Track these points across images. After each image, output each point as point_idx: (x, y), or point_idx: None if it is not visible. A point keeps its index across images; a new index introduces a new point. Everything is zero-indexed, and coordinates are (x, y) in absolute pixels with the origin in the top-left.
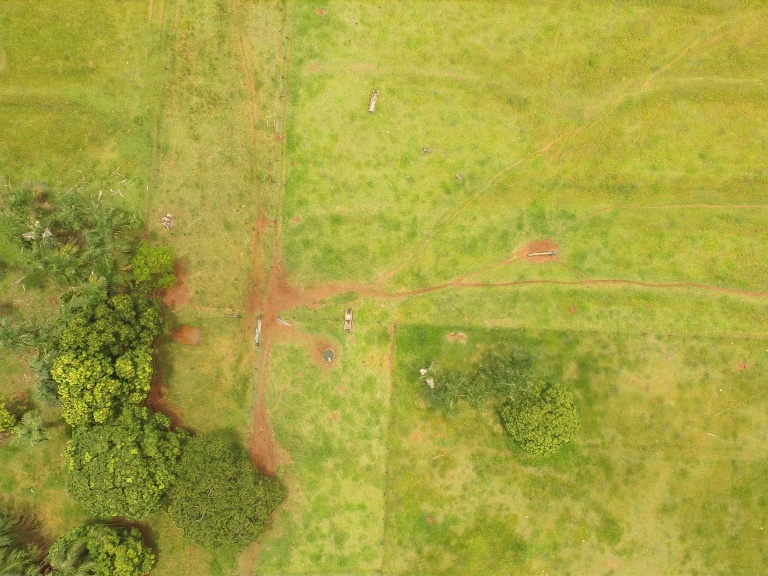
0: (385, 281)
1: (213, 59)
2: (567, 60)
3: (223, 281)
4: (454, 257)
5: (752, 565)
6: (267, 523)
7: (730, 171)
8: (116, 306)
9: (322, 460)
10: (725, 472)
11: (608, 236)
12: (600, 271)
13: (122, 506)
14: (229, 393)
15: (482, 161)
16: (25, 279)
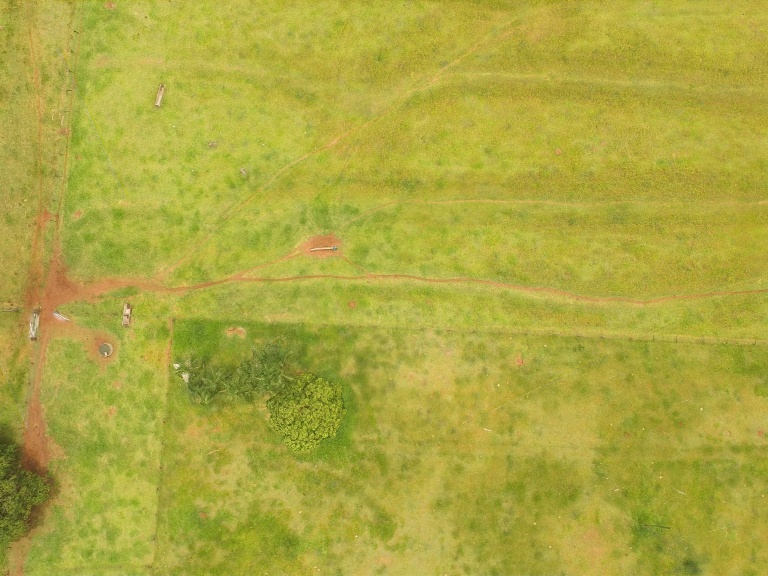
0: (166, 276)
1: (1, 52)
2: (356, 55)
3: (2, 275)
4: (236, 252)
5: (524, 560)
6: (39, 519)
7: (515, 166)
8: None
9: (96, 455)
10: (500, 467)
11: (391, 231)
12: (382, 266)
13: None
14: (4, 388)
15: (268, 156)
16: None
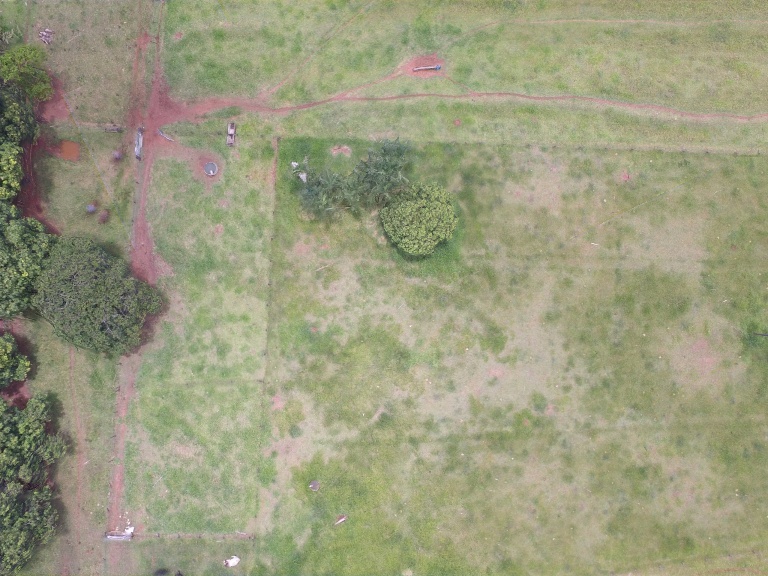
0: (269, 96)
1: None
2: None
3: (104, 96)
4: (339, 72)
5: (634, 371)
6: (148, 335)
7: None
8: None
9: (204, 273)
10: (609, 280)
11: (494, 51)
12: (485, 85)
13: None
14: (110, 207)
15: None
16: None
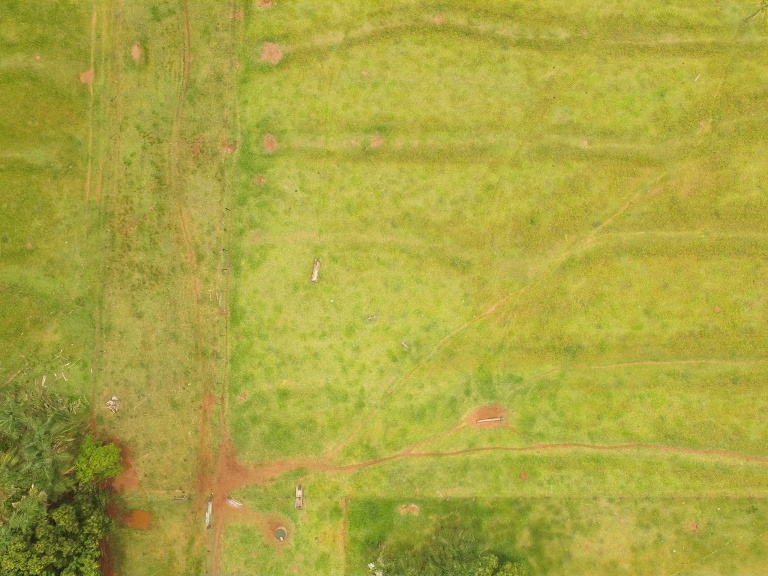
0: (335, 455)
1: (153, 233)
2: (509, 219)
3: (172, 463)
4: (403, 427)
5: None
6: None
7: (675, 326)
8: (57, 522)
9: None
10: None
11: (556, 398)
12: (549, 435)
13: None
14: None
15: (427, 327)
16: None
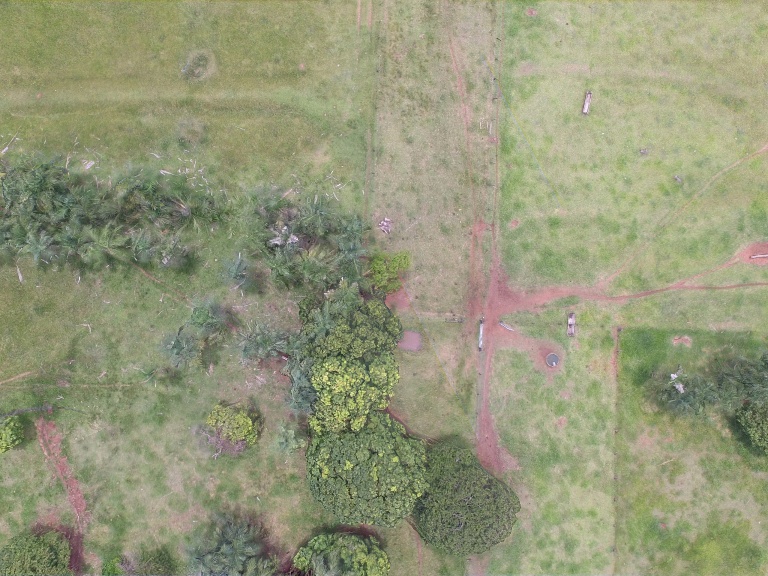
0: (606, 284)
1: (423, 61)
2: None
3: (443, 285)
4: (675, 260)
5: None
6: None
7: None
8: (371, 312)
9: (549, 466)
10: None
11: None
12: None
13: (382, 515)
14: (453, 399)
15: (700, 162)
16: (243, 285)
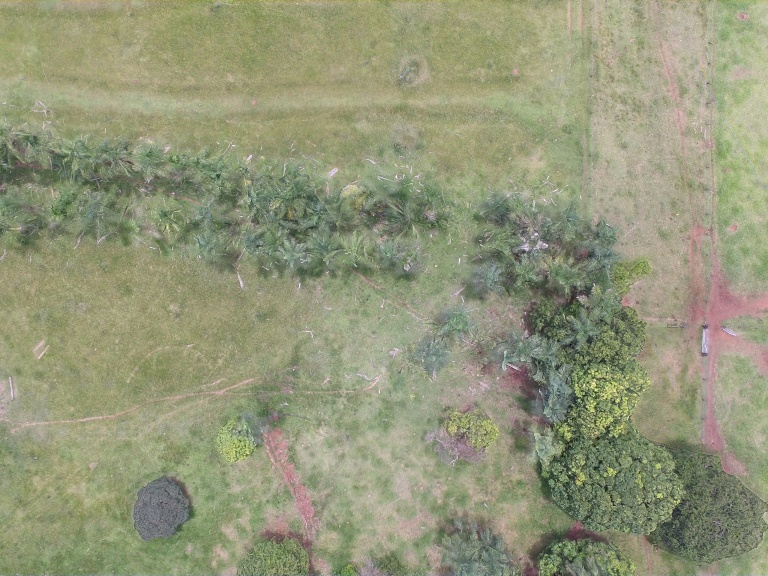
0: None
1: (634, 66)
2: None
3: (663, 291)
4: None
5: None
6: None
7: None
8: (629, 318)
9: None
10: None
11: None
12: None
13: None
14: (678, 404)
15: None
16: (464, 291)
